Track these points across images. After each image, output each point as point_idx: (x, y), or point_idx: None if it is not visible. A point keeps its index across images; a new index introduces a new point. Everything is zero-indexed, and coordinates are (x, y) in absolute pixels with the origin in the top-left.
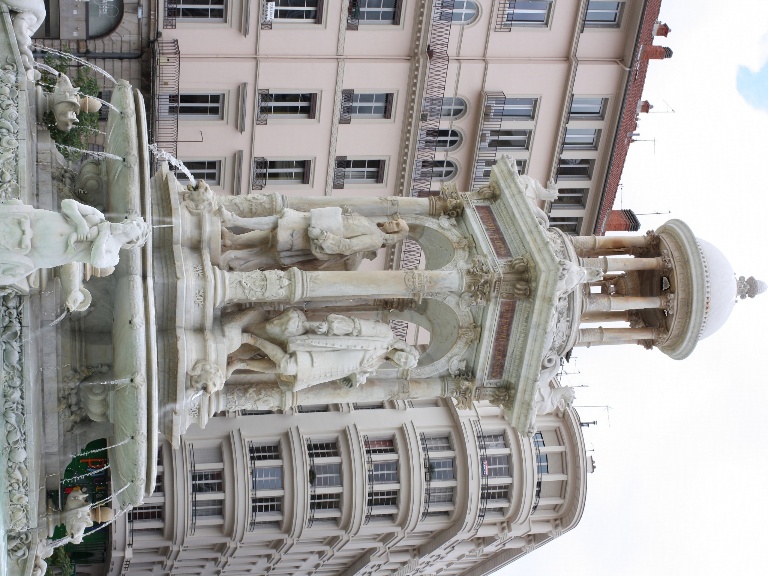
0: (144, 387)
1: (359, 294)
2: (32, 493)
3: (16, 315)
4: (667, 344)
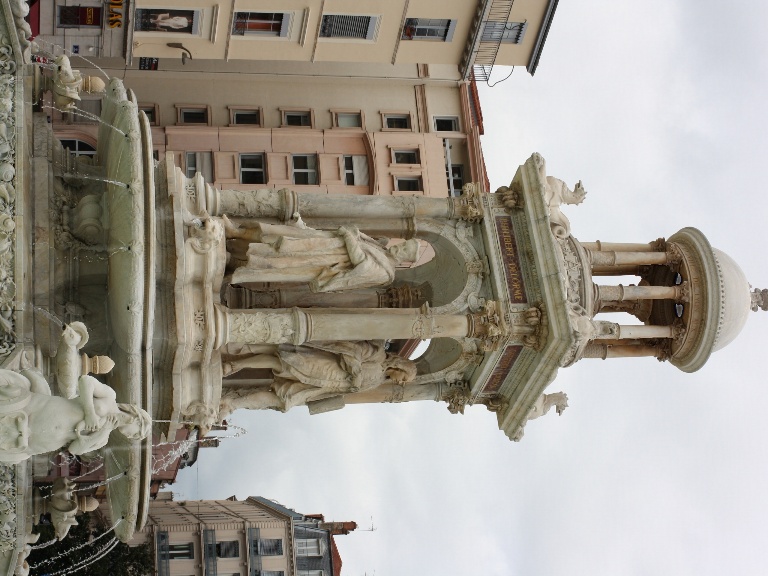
0: None
1: None
2: None
3: None
4: None
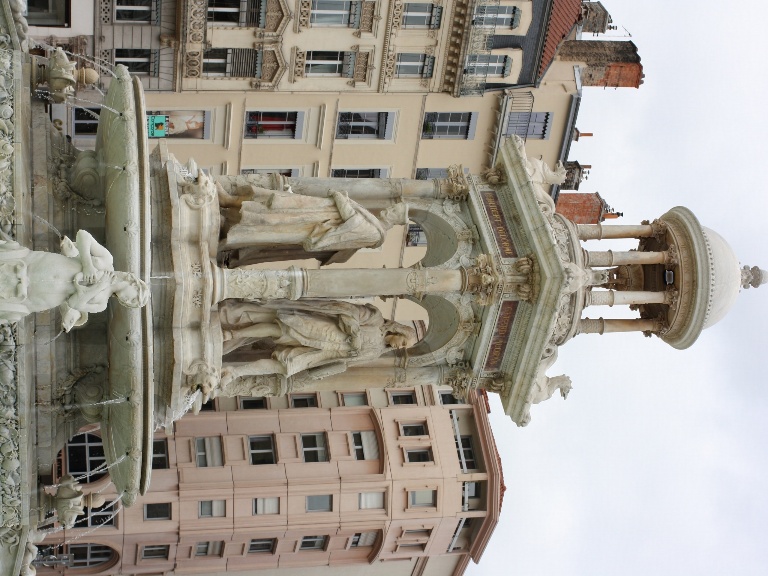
0: None
1: None
2: None
3: None
4: None
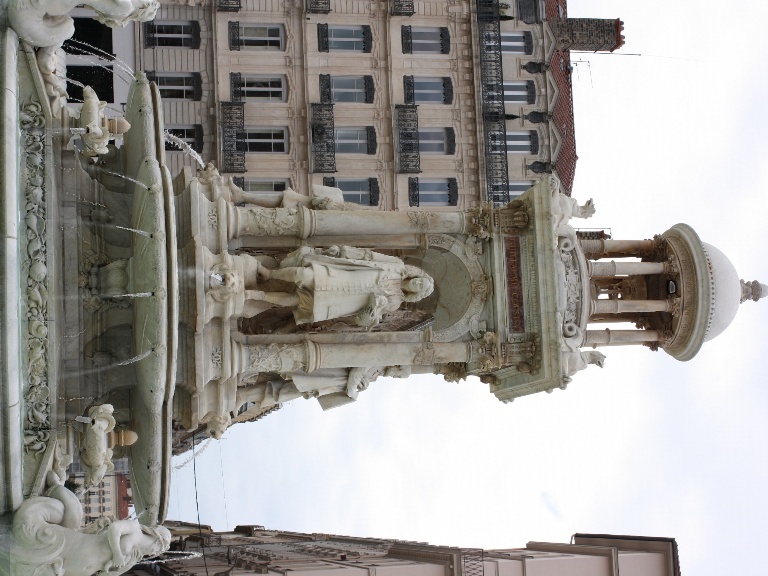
0: (161, 197)
1: (366, 228)
2: (51, 323)
3: (39, 140)
4: (685, 322)
